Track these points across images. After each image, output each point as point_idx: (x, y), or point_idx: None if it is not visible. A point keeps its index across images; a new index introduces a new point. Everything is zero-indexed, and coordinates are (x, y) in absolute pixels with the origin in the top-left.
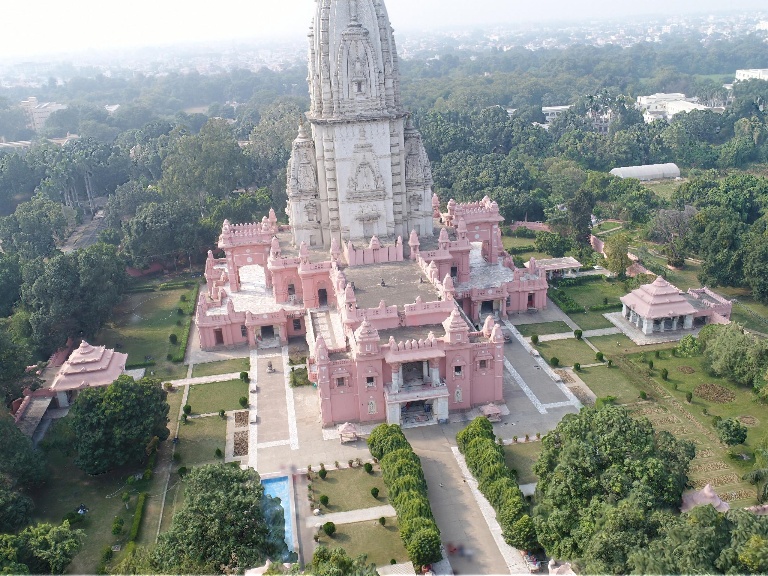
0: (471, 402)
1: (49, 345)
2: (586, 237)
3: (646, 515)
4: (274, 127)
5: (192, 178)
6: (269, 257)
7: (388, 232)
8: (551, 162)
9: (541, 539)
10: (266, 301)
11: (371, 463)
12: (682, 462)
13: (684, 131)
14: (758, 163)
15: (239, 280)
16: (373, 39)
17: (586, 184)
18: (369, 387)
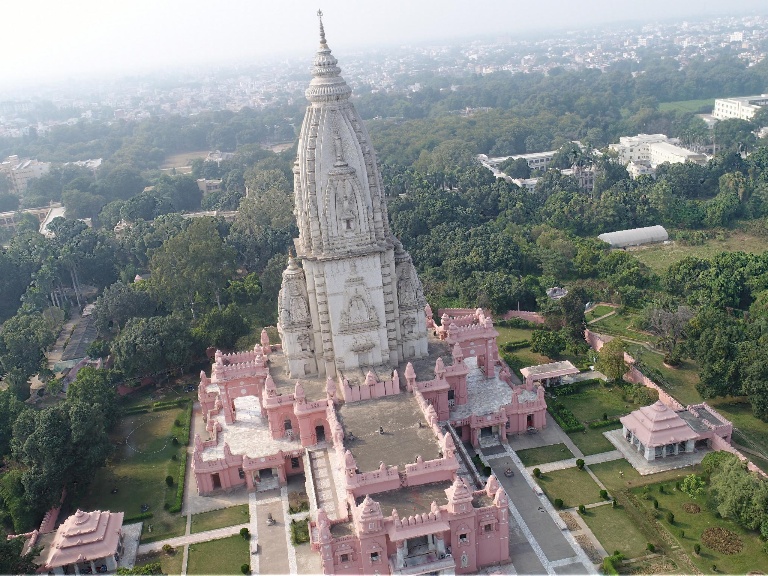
0: (477, 564)
1: (43, 504)
2: (580, 333)
3: None
4: (260, 200)
5: (180, 277)
6: (264, 391)
7: (383, 359)
8: (539, 231)
9: None
10: (262, 436)
11: None
12: None
13: (670, 191)
14: (744, 220)
15: (234, 407)
16: (360, 177)
17: (576, 260)
18: (374, 561)
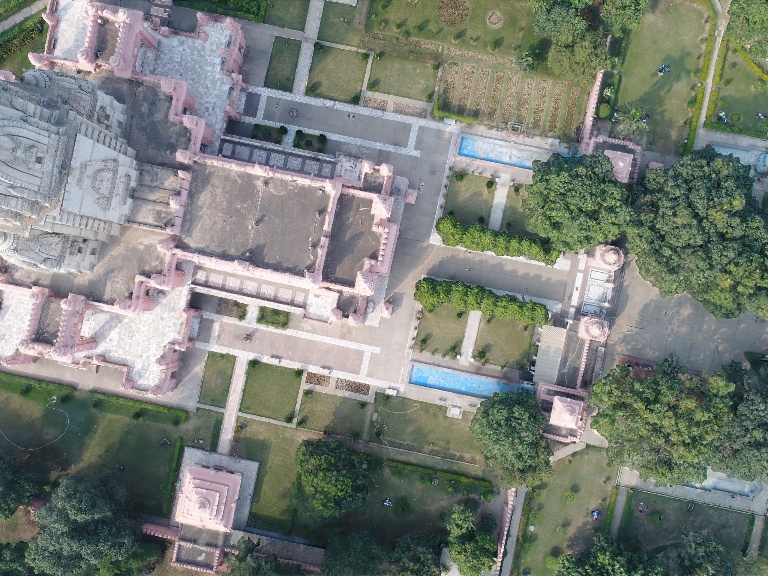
0: None
1: None
2: None
3: None
4: None
5: None
6: (102, 308)
7: (134, 169)
8: None
9: None
10: (140, 320)
11: None
12: None
13: None
14: None
15: None
16: None
17: None
18: None
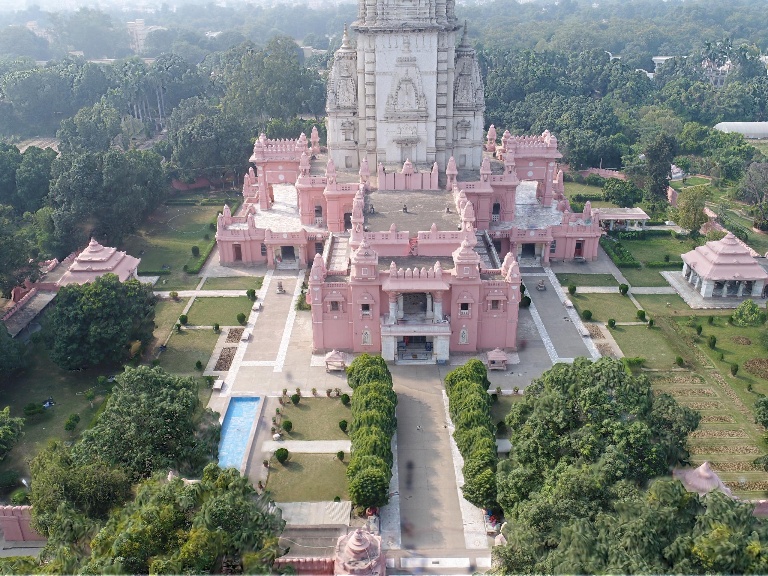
0: (478, 346)
1: (70, 243)
2: (663, 189)
3: (613, 486)
4: None
5: (254, 97)
6: None
7: (428, 159)
8: (647, 110)
9: (499, 498)
10: (292, 221)
11: (351, 395)
12: (677, 432)
13: None
14: None
15: (273, 199)
16: None
17: (680, 135)
18: (364, 315)
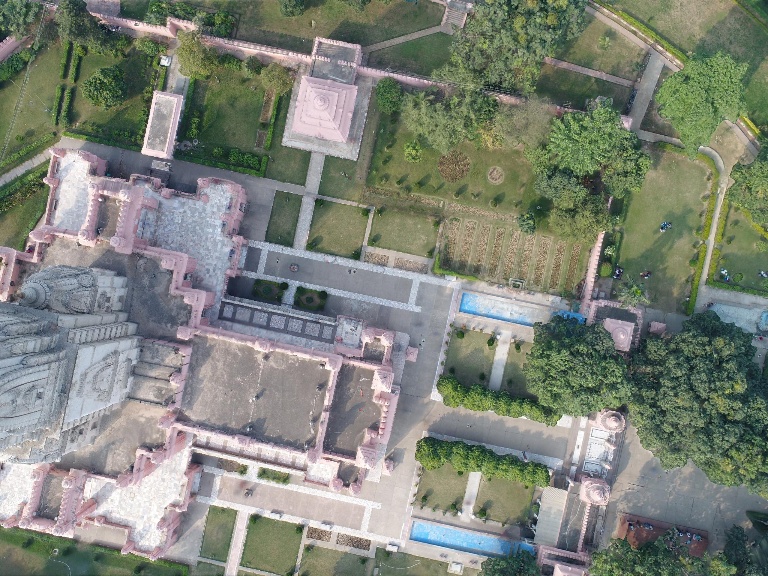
0: None
1: None
2: None
3: None
4: None
5: None
6: (103, 480)
7: (135, 347)
8: None
9: None
10: None
11: None
12: None
13: None
14: None
15: None
16: None
17: None
18: None
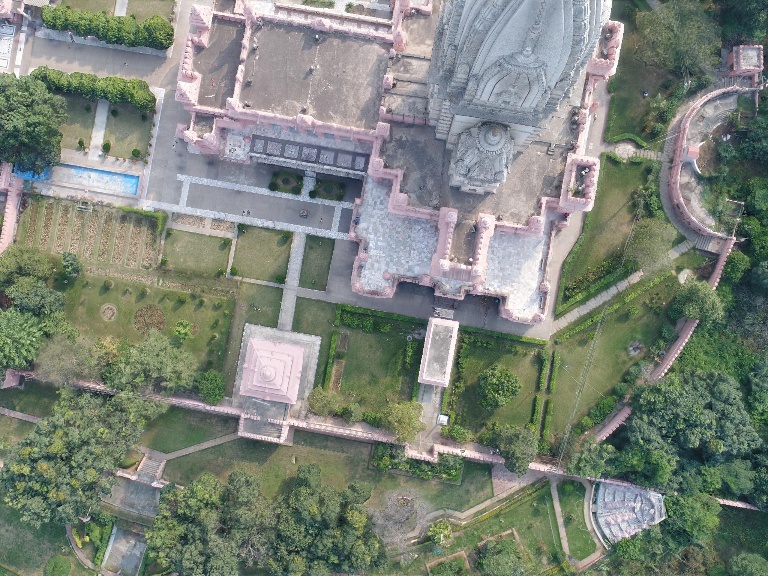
0: None
1: None
2: None
3: None
4: None
5: None
6: None
7: None
8: None
9: None
10: None
11: None
12: None
13: None
14: None
15: None
16: None
17: None
18: None
